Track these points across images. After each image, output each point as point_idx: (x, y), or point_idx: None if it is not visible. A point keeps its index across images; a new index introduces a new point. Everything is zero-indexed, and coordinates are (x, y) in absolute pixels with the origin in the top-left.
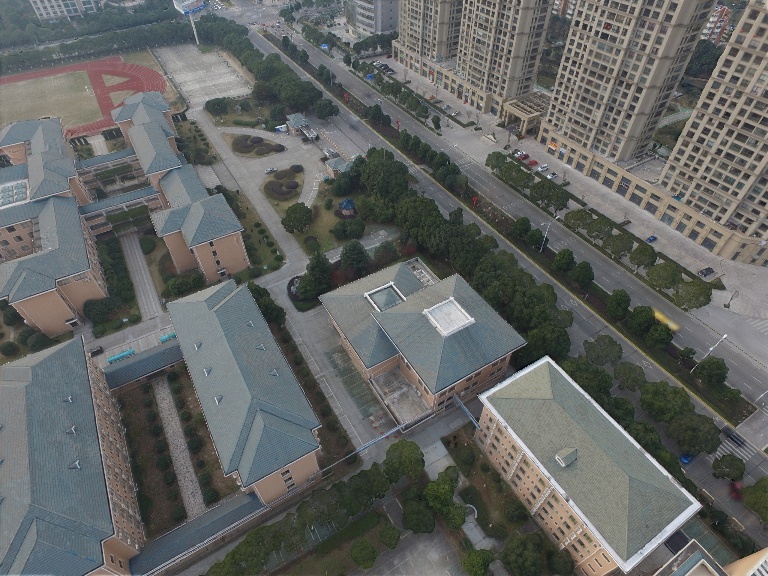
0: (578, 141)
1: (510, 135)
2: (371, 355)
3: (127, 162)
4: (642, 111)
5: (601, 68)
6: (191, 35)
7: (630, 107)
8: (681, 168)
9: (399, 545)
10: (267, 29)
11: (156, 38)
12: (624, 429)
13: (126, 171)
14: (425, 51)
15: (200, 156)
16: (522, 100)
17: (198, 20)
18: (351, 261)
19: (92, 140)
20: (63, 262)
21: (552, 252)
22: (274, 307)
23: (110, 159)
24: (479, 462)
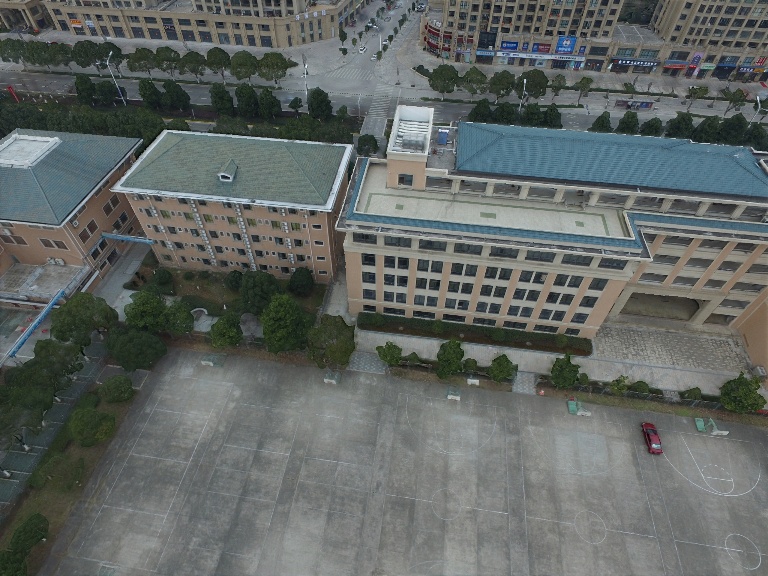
0: (96, 5)
1: (15, 26)
2: None
3: None
4: None
5: None
6: None
7: None
8: None
9: (141, 395)
10: None
11: None
12: None
13: None
14: None
15: None
16: None
17: None
18: None
19: None
20: None
21: (138, 101)
22: None
23: None
24: (180, 277)
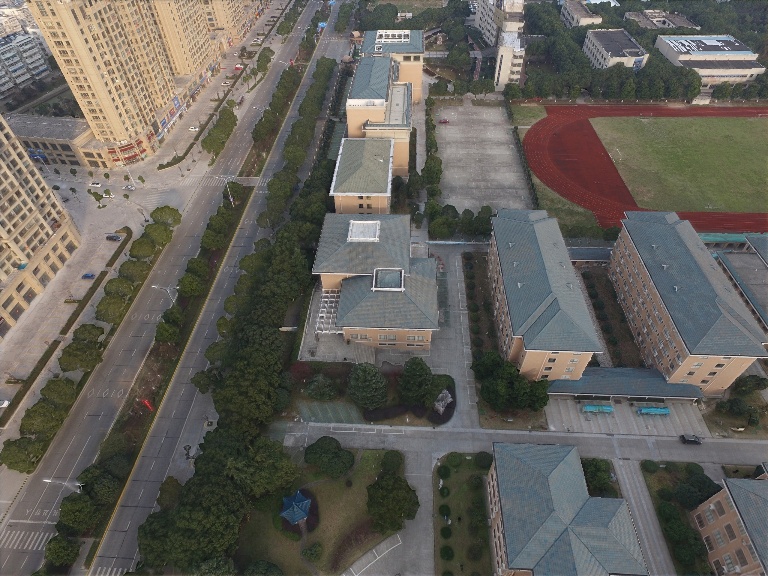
0: None
1: None
2: (428, 260)
3: None
4: None
5: None
6: None
7: None
8: None
9: None
10: None
11: None
12: None
13: None
14: None
15: None
16: None
17: None
18: None
19: None
20: None
21: None
22: None
23: None
24: None
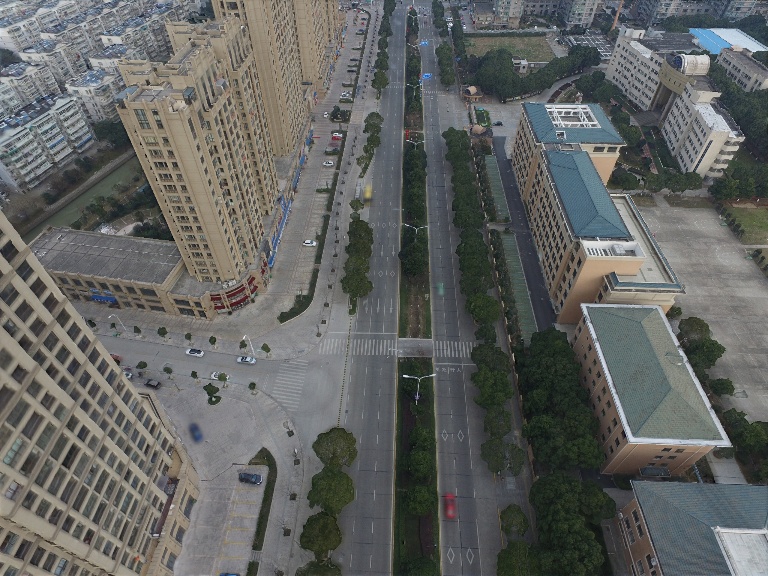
0: None
1: None
2: None
3: None
4: None
5: None
6: None
7: None
8: None
9: None
10: None
11: None
12: None
13: None
14: None
15: None
16: None
17: None
18: None
19: None
20: None
21: None
22: None
23: None
24: None
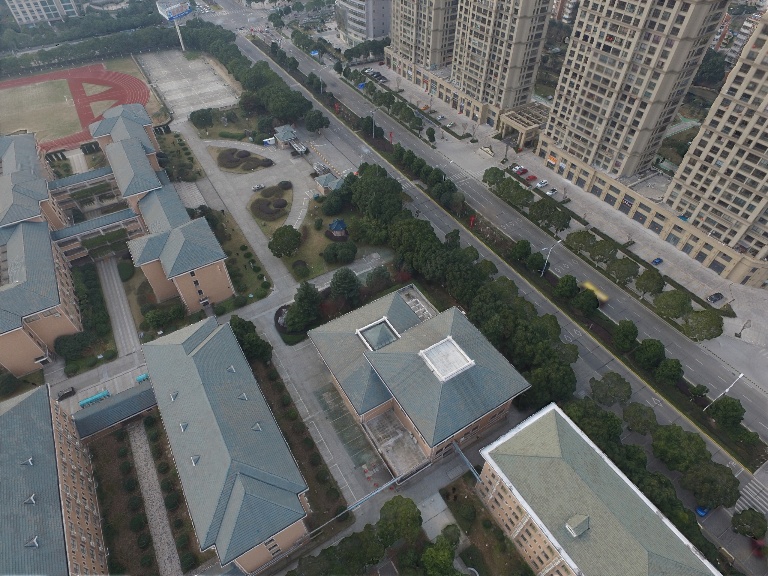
0: (578, 156)
1: None
2: (363, 400)
3: (105, 180)
4: (646, 126)
5: (603, 81)
6: (176, 41)
7: (633, 122)
8: (687, 187)
9: None
10: (255, 34)
11: (140, 44)
12: (638, 485)
13: (105, 189)
14: (418, 59)
15: (183, 172)
16: (519, 111)
17: (184, 25)
18: (342, 290)
19: (70, 155)
20: (30, 297)
21: (554, 276)
22: (259, 343)
23: (87, 178)
24: (481, 517)
